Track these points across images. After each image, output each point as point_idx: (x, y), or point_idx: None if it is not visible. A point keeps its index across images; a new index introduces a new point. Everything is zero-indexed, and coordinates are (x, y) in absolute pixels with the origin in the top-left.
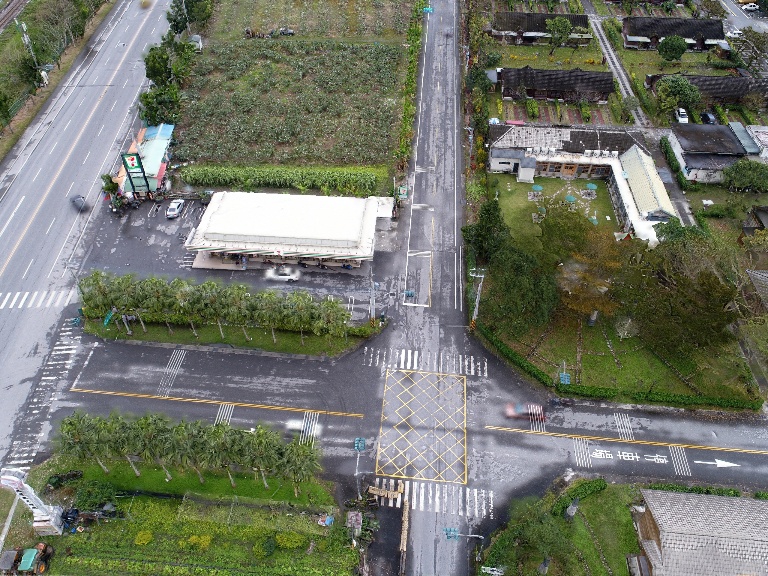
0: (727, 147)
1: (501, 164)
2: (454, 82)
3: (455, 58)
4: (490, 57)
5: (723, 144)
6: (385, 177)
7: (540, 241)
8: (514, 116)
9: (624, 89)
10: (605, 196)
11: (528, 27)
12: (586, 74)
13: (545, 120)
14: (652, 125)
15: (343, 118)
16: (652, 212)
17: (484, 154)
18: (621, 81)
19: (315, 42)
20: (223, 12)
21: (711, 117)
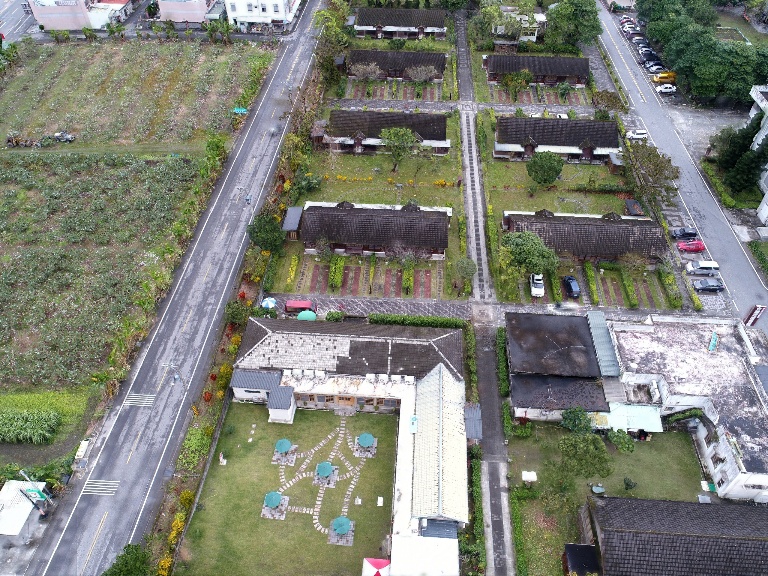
0: (575, 364)
1: (248, 392)
2: (248, 223)
3: (266, 179)
4: (304, 183)
5: (571, 357)
6: (78, 414)
7: (254, 565)
8: (310, 284)
9: (474, 230)
10: (389, 451)
11: (369, 132)
12: (412, 221)
13: (350, 291)
14: (495, 299)
15: (72, 291)
16: (423, 524)
17: (225, 376)
18: (474, 216)
19: (88, 157)
20: (1, 104)
21: (575, 288)
